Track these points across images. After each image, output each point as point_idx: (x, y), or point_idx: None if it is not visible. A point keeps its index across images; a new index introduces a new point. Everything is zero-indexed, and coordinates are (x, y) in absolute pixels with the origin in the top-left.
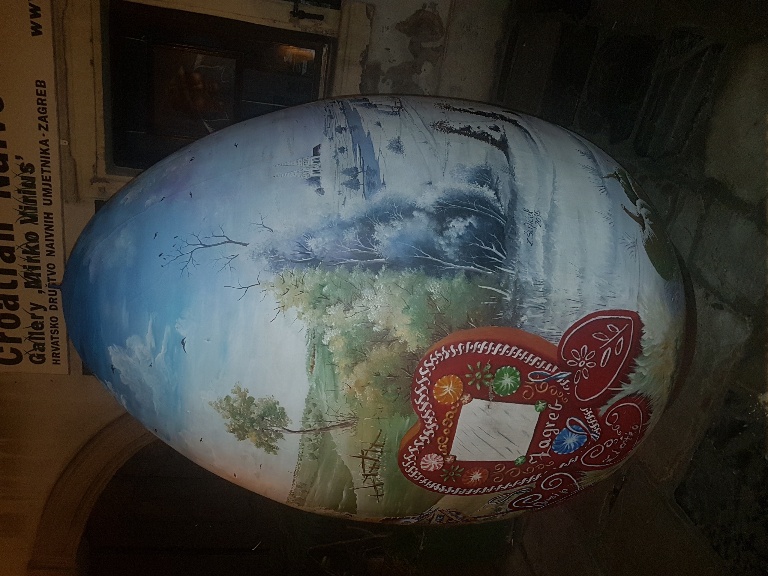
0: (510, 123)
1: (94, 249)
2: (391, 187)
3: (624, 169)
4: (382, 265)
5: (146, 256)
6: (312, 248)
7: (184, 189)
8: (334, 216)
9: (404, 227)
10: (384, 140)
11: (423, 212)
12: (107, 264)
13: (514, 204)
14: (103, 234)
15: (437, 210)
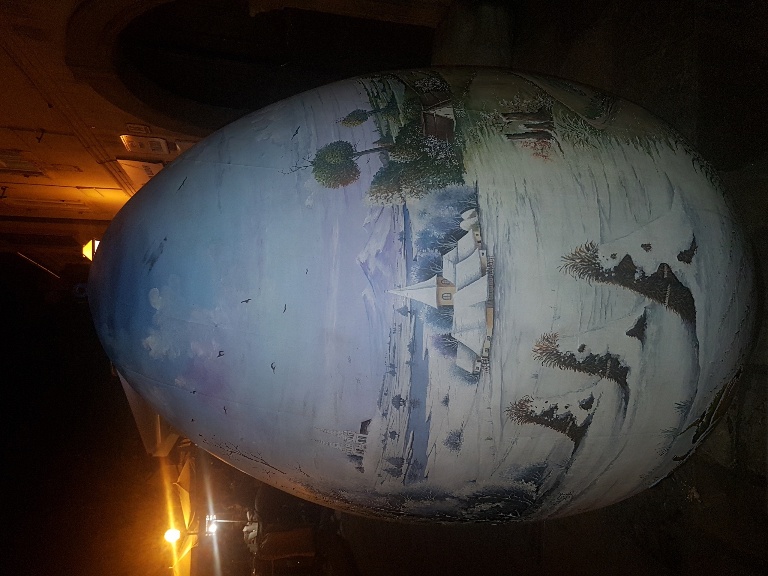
0: (615, 383)
1: (126, 369)
2: (433, 481)
3: (738, 362)
4: (404, 514)
5: (186, 425)
6: (345, 496)
7: (217, 397)
8: (369, 488)
9: (433, 504)
10: (444, 431)
11: (456, 499)
12: (146, 396)
13: (551, 492)
14: (132, 366)
15: (470, 499)
